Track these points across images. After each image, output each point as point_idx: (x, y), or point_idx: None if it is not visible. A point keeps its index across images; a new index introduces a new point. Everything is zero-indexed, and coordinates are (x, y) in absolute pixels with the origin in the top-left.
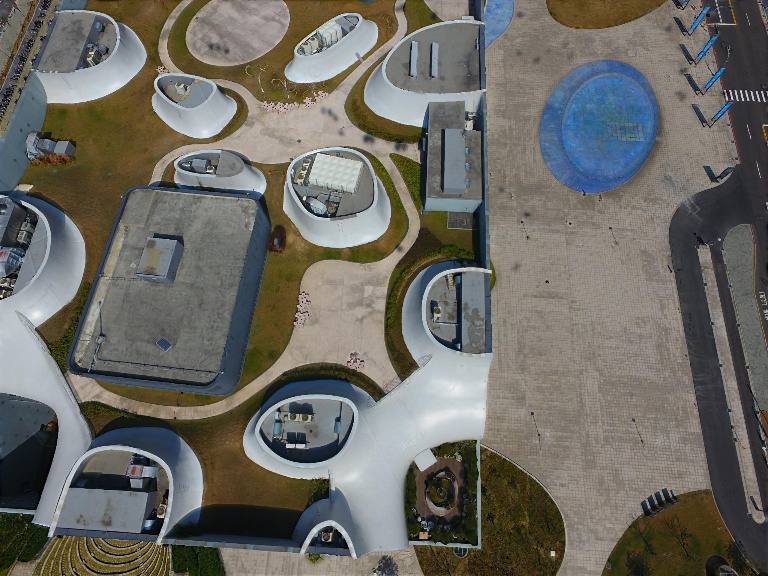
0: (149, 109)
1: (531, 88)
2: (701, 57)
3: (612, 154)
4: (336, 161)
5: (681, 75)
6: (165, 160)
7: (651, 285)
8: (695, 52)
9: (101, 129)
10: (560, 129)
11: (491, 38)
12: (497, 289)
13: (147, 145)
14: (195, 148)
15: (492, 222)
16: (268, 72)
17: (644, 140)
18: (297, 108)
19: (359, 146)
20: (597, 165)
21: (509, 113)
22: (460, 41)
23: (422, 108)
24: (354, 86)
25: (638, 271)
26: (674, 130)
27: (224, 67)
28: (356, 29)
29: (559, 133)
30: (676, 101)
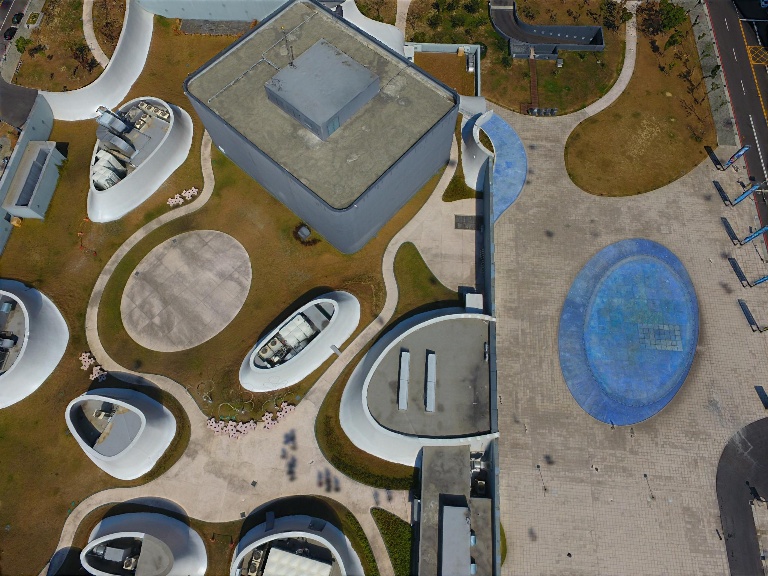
0: (64, 426)
1: (548, 277)
2: (748, 240)
3: (645, 369)
4: (296, 563)
5: (724, 260)
6: (79, 512)
7: (697, 559)
8: (740, 228)
9: (3, 453)
10: (582, 333)
11: (501, 208)
12: (508, 565)
13: (58, 483)
14: (118, 495)
15: (502, 466)
16: (220, 367)
17: (683, 349)
18: (253, 430)
19: (331, 495)
20: (627, 384)
21: (522, 311)
22: (464, 345)
23: (414, 449)
24: (328, 393)
25: (680, 538)
26: (718, 336)
27: (165, 353)
28: (330, 326)
29: (581, 338)
30: (719, 295)
